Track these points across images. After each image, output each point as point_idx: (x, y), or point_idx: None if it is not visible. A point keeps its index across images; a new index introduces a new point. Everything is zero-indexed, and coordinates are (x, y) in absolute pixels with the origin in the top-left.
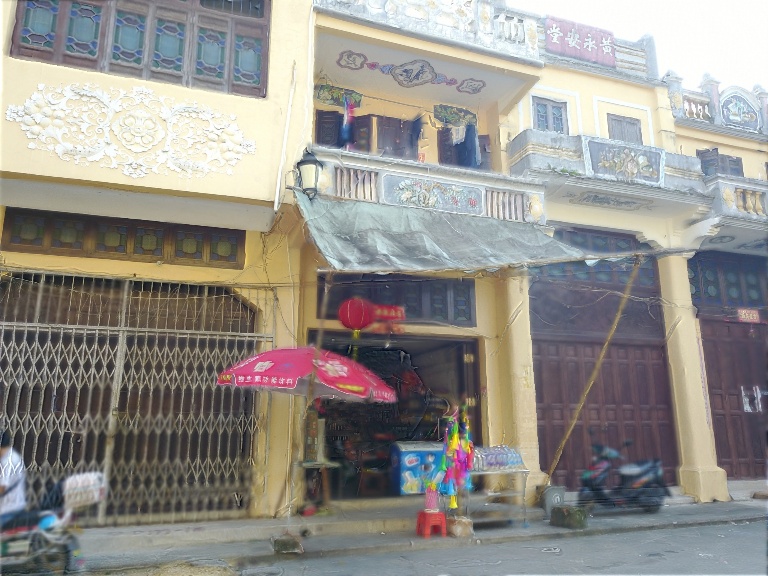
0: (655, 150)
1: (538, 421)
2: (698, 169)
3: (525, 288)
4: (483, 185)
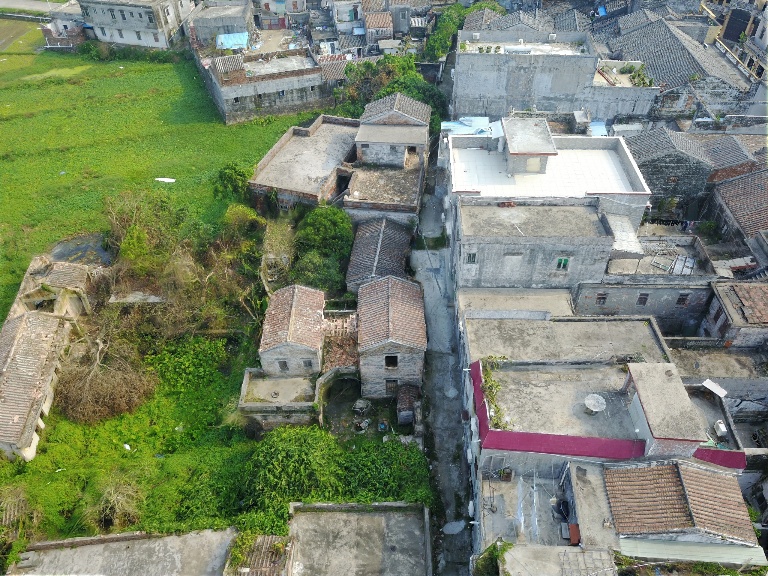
0: (747, 4)
1: (726, 31)
2: (754, 7)
3: (728, 16)
4: (720, 7)
